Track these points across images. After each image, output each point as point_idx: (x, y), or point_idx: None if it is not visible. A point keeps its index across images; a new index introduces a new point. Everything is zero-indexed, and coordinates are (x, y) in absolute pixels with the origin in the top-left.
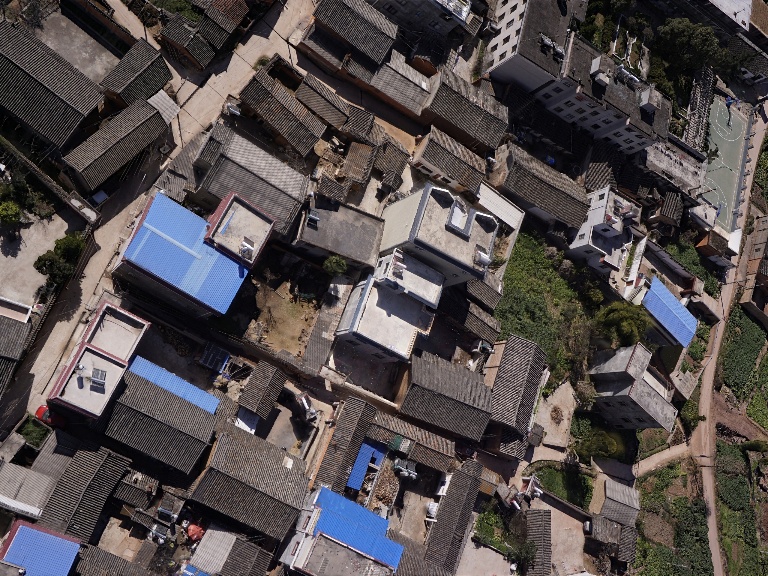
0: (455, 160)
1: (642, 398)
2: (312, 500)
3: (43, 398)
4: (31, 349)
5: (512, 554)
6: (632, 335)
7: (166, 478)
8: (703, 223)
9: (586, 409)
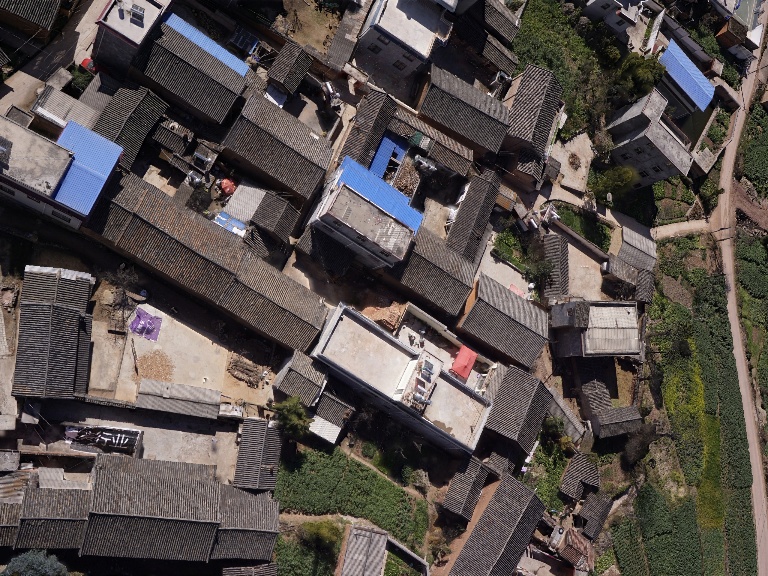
0: None
1: (658, 139)
2: (337, 172)
3: (88, 54)
4: (76, 10)
5: (530, 273)
6: (648, 83)
7: (201, 133)
8: (722, 10)
9: (604, 162)
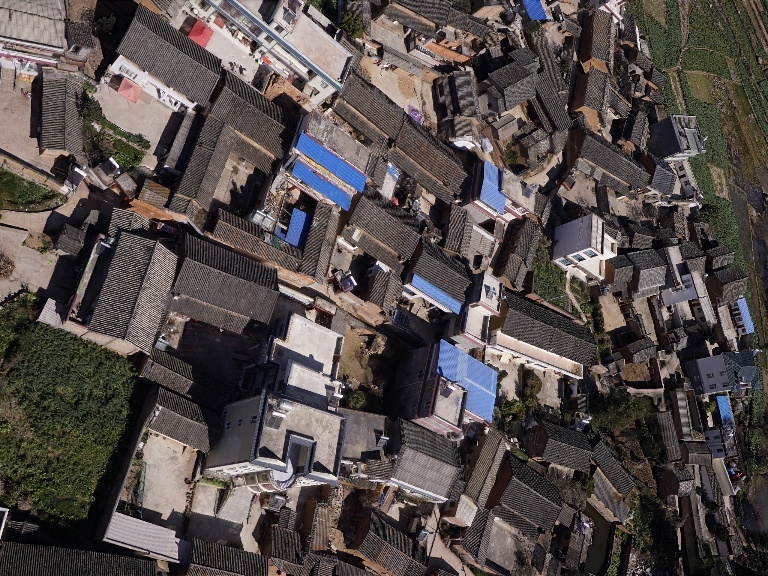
0: (232, 568)
1: None
2: None
3: None
4: None
5: None
6: None
7: None
8: None
9: None
